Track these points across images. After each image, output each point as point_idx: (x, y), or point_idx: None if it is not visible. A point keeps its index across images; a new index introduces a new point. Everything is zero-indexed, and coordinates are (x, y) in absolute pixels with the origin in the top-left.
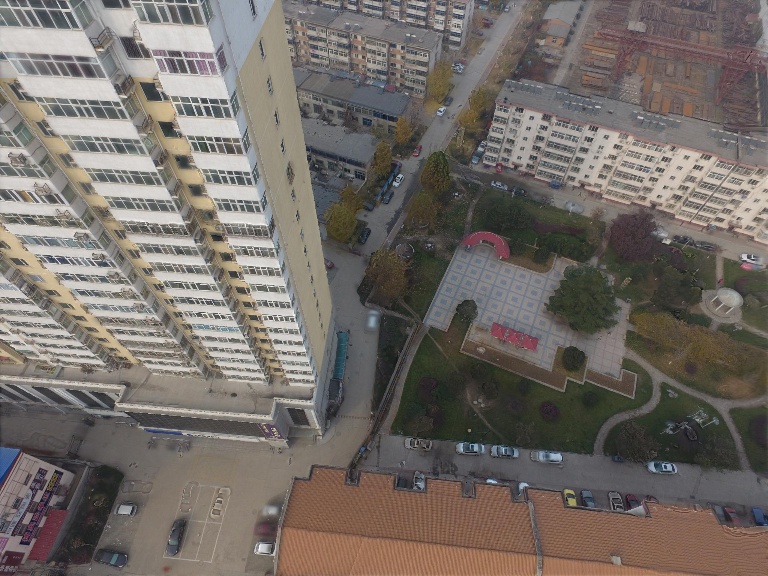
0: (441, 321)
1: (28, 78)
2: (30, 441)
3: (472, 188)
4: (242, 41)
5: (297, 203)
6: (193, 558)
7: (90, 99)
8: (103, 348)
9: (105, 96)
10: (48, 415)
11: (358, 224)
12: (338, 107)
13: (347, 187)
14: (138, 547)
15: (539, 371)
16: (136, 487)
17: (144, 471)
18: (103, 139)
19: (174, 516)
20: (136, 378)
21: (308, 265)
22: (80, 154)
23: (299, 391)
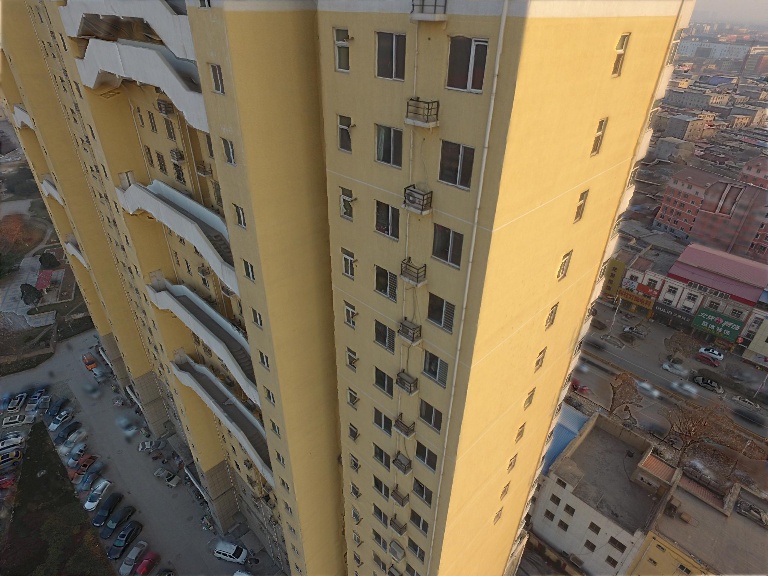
0: (45, 318)
1: None
2: None
3: None
4: None
5: None
6: None
7: None
8: None
9: None
10: None
11: None
12: None
13: None
14: None
15: (68, 272)
16: None
17: None
18: None
19: None
20: None
21: None
22: None
23: None
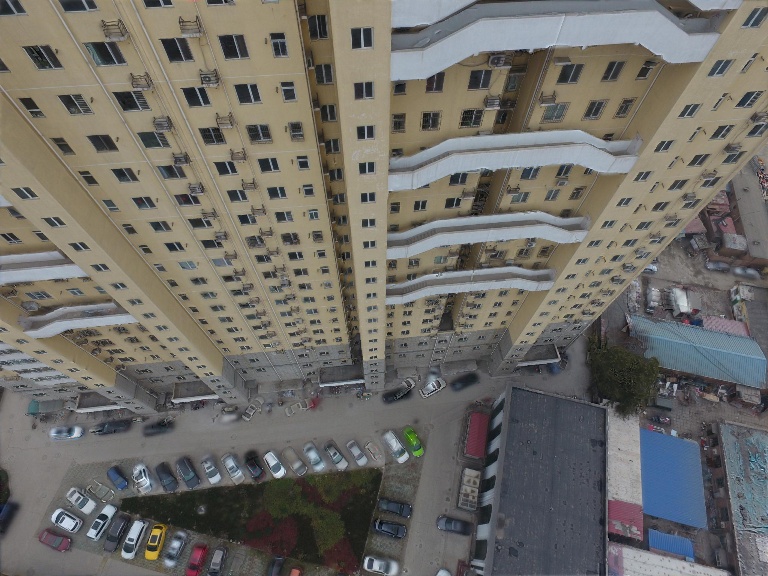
0: None
1: None
2: None
3: None
4: None
5: None
6: None
7: None
8: None
9: None
10: None
11: None
12: None
13: None
14: None
15: None
16: None
17: None
18: None
19: None
20: None
21: None
22: None
23: None
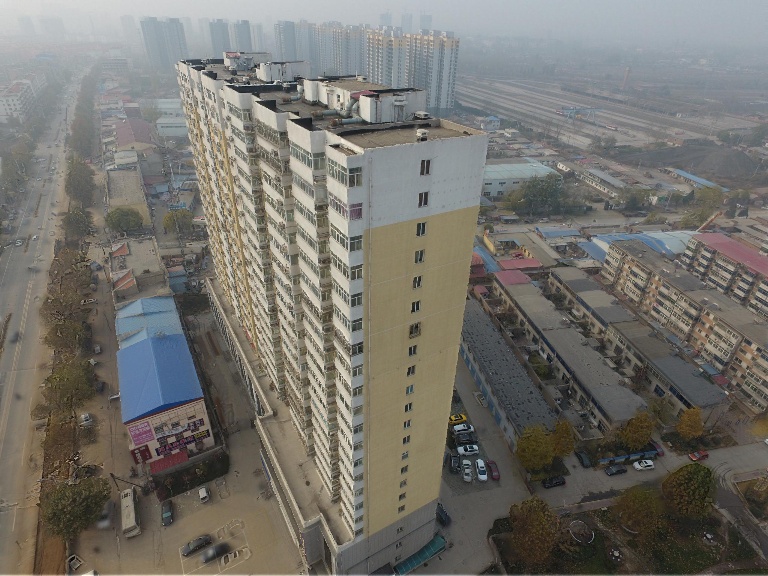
0: None
1: (294, 186)
2: (225, 406)
3: (741, 549)
4: (392, 212)
5: (417, 360)
6: (185, 572)
7: (307, 207)
8: (285, 379)
9: (311, 208)
10: (246, 400)
11: (557, 466)
12: (638, 360)
13: (565, 422)
14: (181, 524)
15: None
16: (222, 487)
17: (236, 483)
18: (307, 233)
19: (212, 531)
20: (283, 415)
21: (408, 423)
22: (299, 237)
23: (342, 530)
